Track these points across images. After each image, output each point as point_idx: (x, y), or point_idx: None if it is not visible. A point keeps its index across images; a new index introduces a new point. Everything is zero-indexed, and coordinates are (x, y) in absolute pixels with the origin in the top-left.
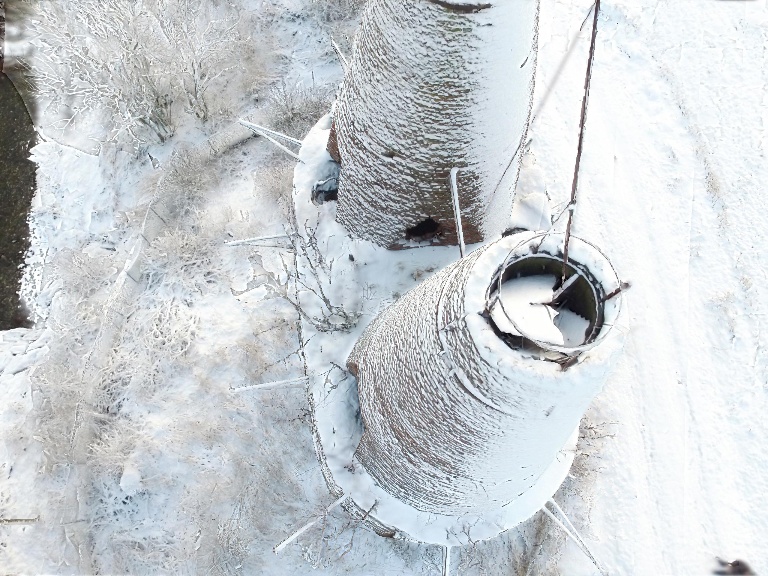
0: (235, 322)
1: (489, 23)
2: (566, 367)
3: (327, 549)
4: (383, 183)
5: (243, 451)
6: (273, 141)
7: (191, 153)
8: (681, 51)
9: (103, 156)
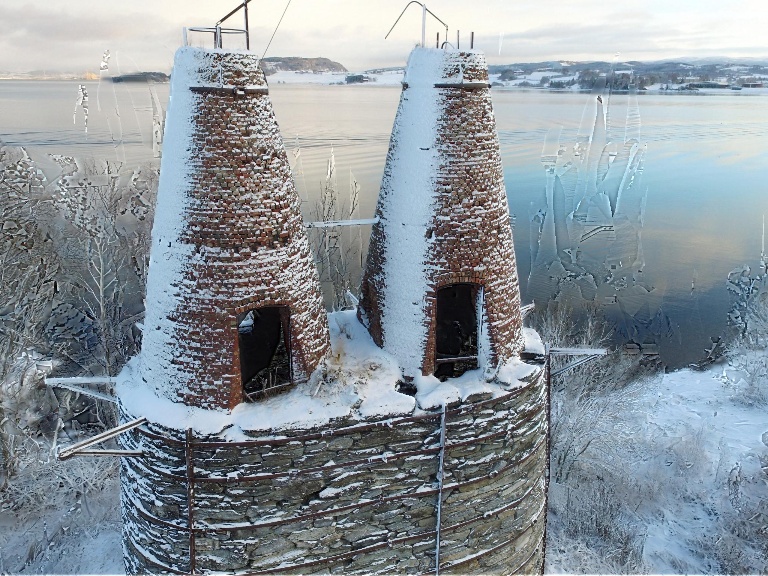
0: None
1: None
2: None
3: None
4: None
5: None
6: None
7: None
8: None
9: None
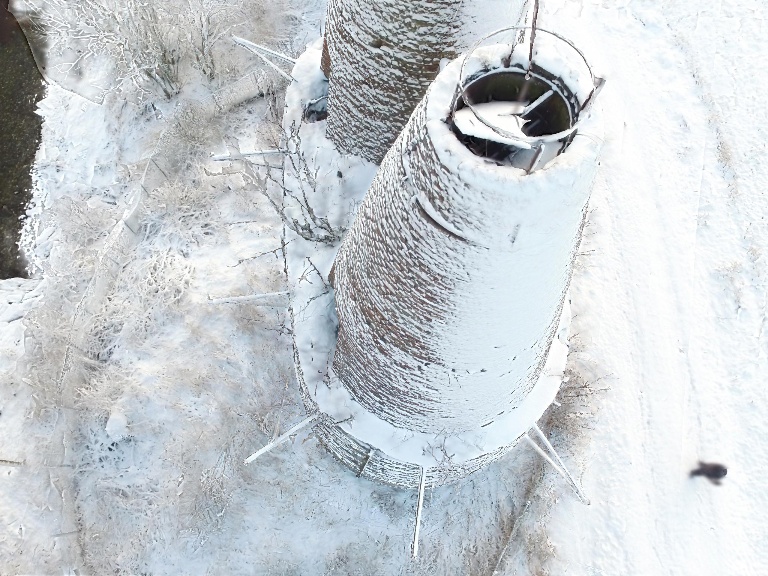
0: (230, 272)
1: None
2: (530, 167)
3: (311, 502)
4: (371, 81)
5: (231, 400)
6: (267, 61)
7: (195, 107)
8: (697, 20)
9: (109, 111)
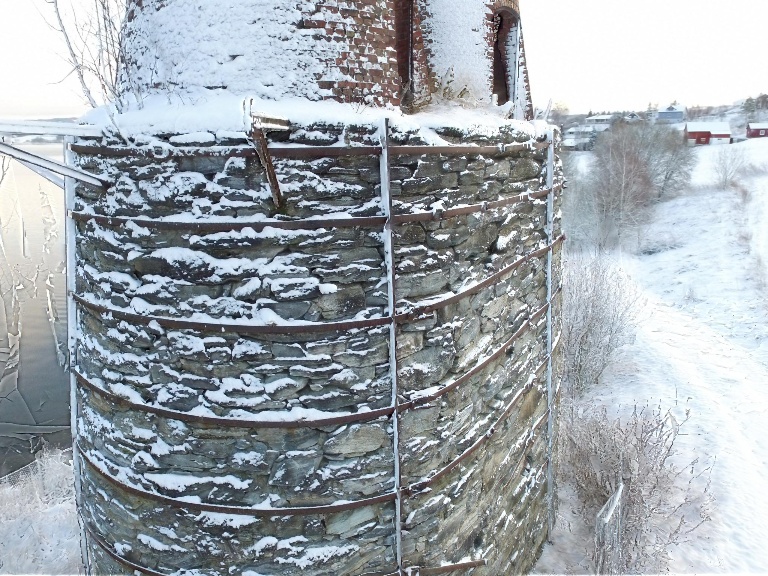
0: None
1: None
2: None
3: None
4: None
5: None
6: None
7: None
8: None
9: None
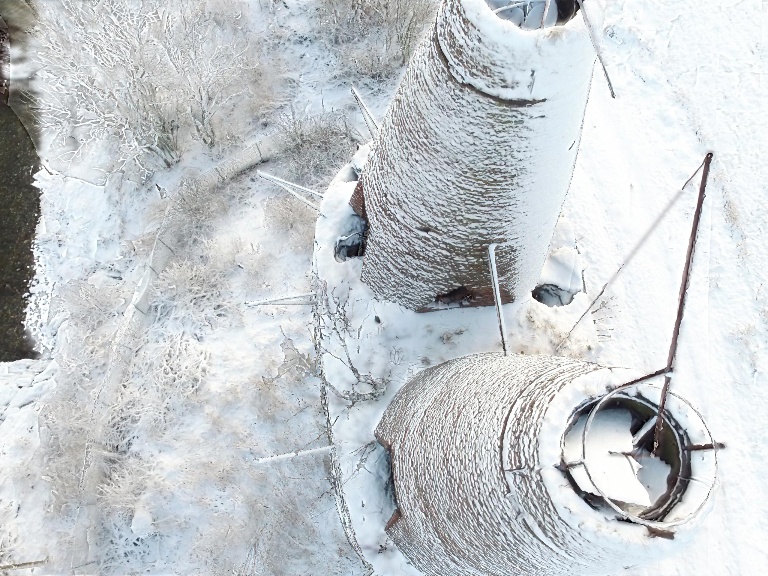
0: (247, 358)
1: (542, 115)
2: (656, 535)
3: None
4: (415, 254)
5: (257, 492)
6: (293, 193)
7: (199, 181)
8: (697, 75)
9: (108, 182)
